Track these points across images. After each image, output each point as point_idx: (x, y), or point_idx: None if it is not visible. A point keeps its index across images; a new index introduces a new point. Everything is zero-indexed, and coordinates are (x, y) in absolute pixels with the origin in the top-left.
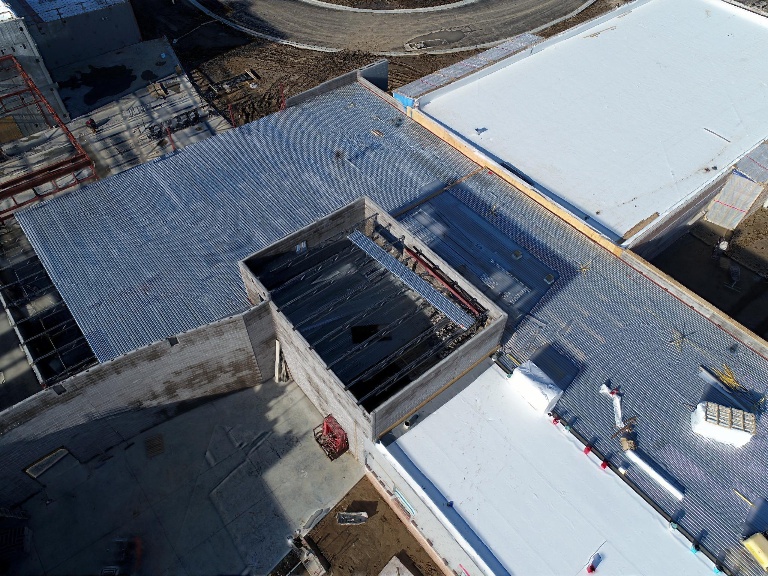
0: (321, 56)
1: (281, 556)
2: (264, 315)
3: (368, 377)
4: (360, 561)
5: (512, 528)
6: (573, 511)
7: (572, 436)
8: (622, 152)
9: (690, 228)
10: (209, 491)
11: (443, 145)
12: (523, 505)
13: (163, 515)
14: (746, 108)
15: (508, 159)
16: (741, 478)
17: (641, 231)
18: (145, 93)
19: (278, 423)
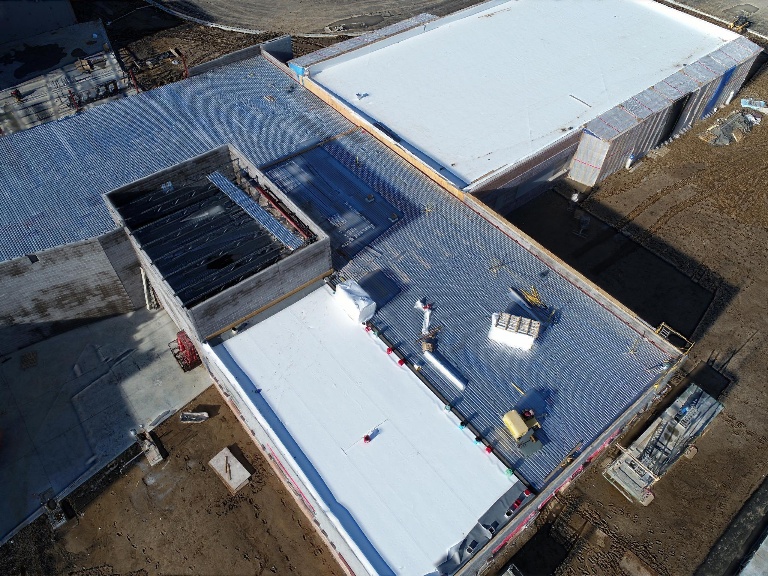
0: (244, 37)
1: (126, 447)
2: (122, 240)
3: (199, 287)
4: (196, 452)
5: (307, 409)
6: (364, 397)
7: (380, 340)
8: (489, 115)
9: (553, 185)
10: (71, 396)
11: (327, 109)
12: (322, 392)
13: (27, 414)
14: (614, 78)
15: (382, 120)
16: (520, 374)
17: (484, 178)
18: (72, 68)
19: (143, 342)
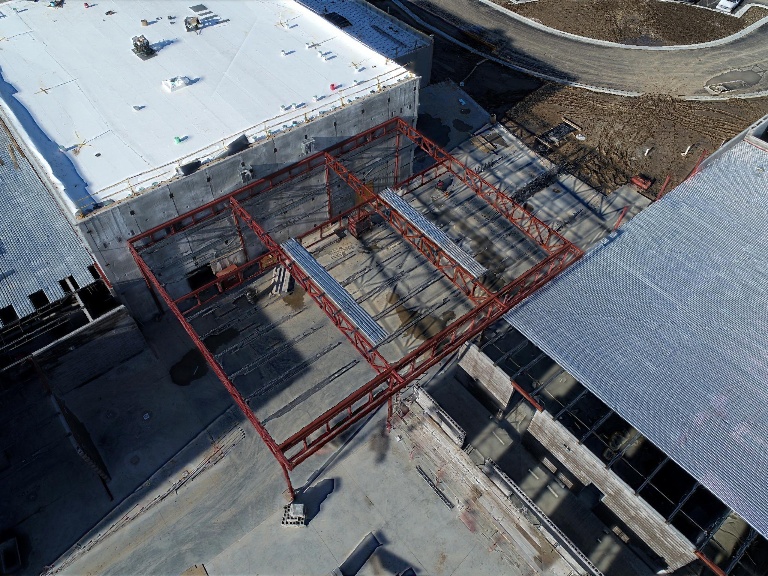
0: (628, 101)
1: None
2: None
3: None
4: None
5: None
6: None
7: None
8: None
9: None
10: None
11: None
12: None
13: None
14: None
15: None
16: None
17: None
18: (471, 147)
19: None
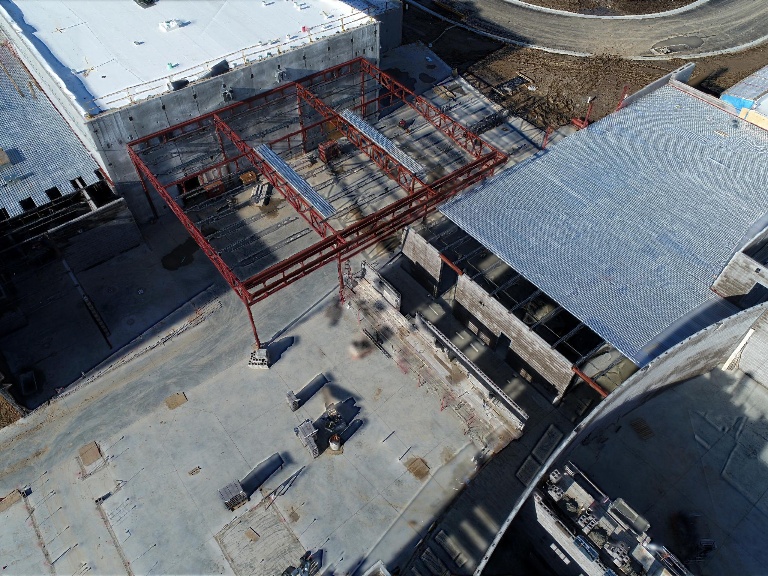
0: (579, 60)
1: None
2: None
3: None
4: None
5: None
6: None
7: None
8: None
9: None
10: (719, 472)
11: None
12: None
13: (689, 494)
14: None
15: None
16: None
17: None
18: (433, 95)
19: (747, 409)
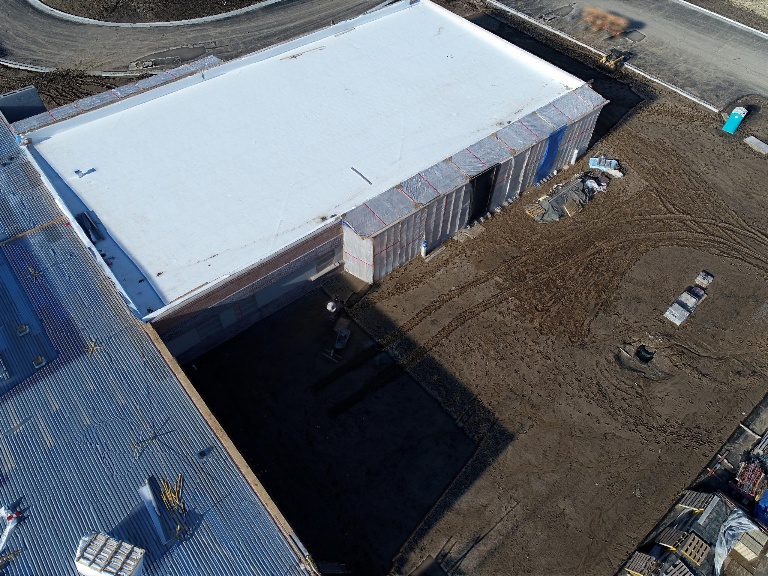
0: (26, 77)
1: None
2: None
3: None
4: None
5: None
6: None
7: None
8: (237, 197)
9: (323, 282)
10: None
11: (41, 189)
12: None
13: None
14: (415, 143)
15: (96, 207)
16: None
17: (179, 300)
18: None
19: None
